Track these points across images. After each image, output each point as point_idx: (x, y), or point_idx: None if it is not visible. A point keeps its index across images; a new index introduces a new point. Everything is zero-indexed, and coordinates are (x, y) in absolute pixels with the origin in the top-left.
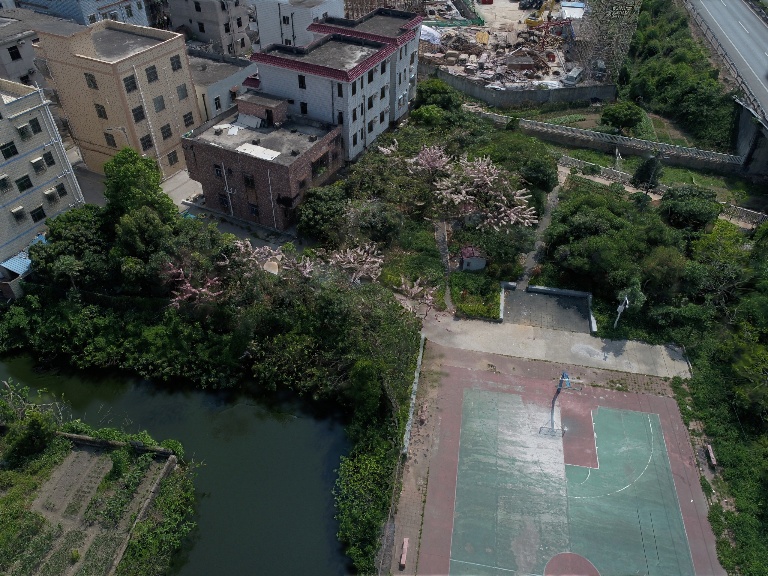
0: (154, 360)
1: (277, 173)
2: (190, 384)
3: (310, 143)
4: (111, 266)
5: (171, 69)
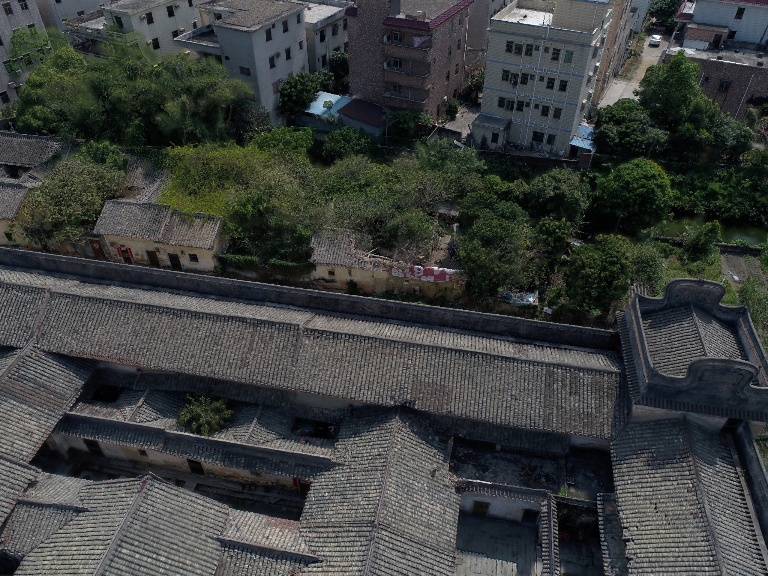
0: (723, 205)
1: (761, 77)
2: (747, 223)
3: (760, 59)
4: (681, 138)
5: (629, 5)
